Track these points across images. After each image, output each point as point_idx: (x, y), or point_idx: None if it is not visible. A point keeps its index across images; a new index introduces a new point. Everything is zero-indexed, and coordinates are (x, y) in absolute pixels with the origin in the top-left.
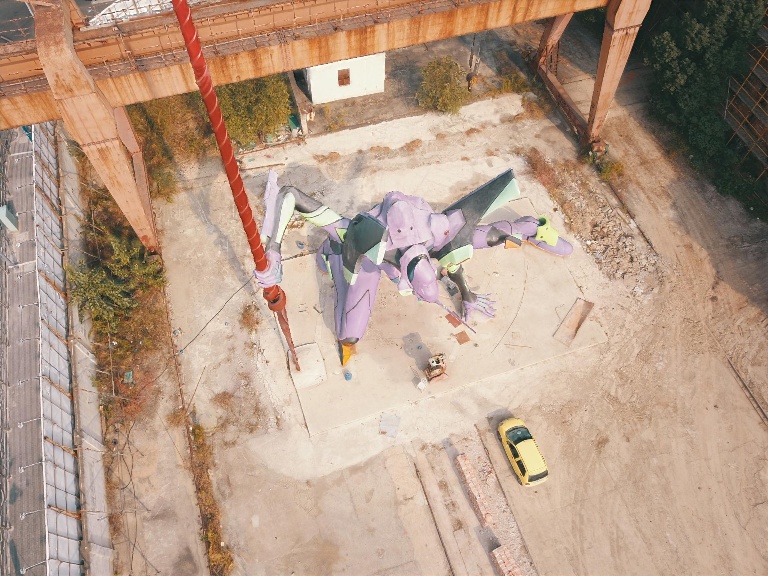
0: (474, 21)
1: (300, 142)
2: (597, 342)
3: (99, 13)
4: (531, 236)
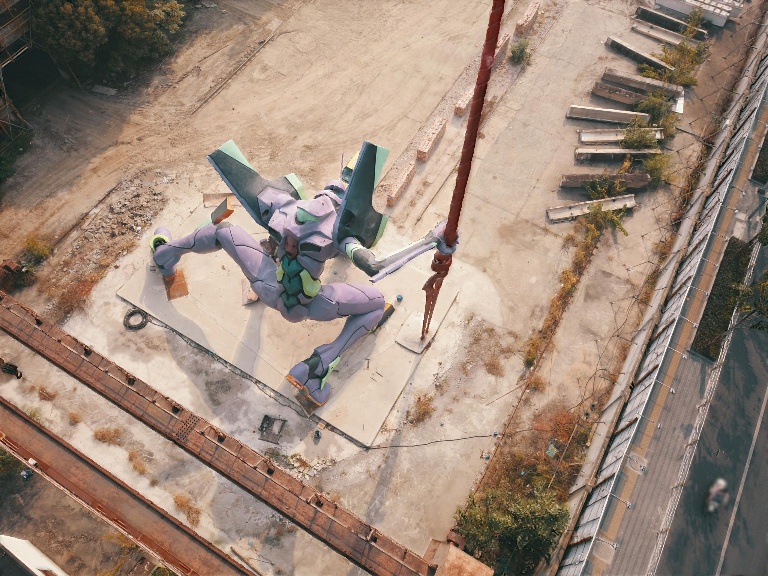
0: None
1: None
2: None
3: None
4: None
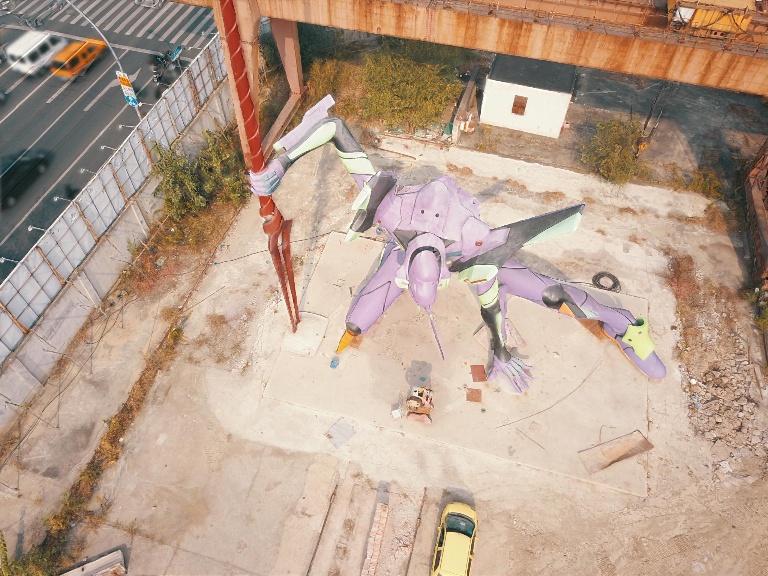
0: (652, 62)
1: (444, 147)
2: (630, 490)
3: None
4: (620, 335)
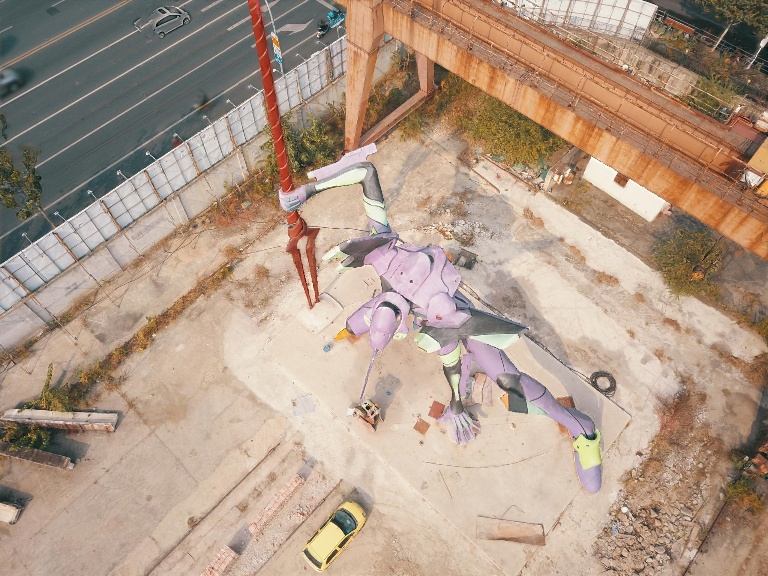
0: (707, 210)
1: (532, 190)
2: (502, 568)
3: None
4: None
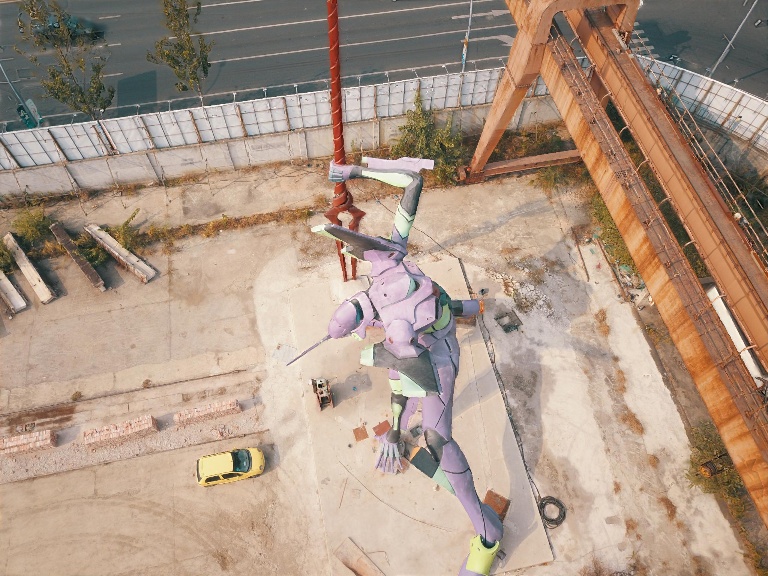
0: (717, 402)
1: (623, 297)
2: None
3: (734, 87)
4: None
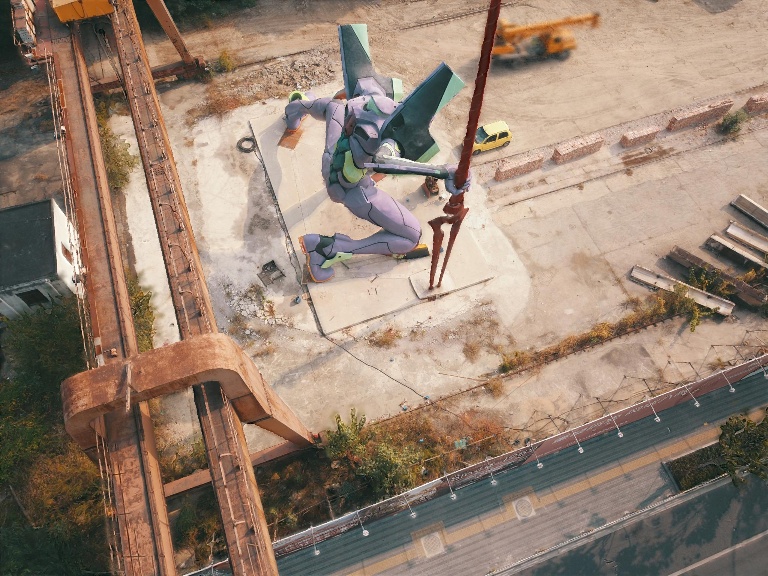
0: (140, 37)
1: None
2: None
3: None
4: None
